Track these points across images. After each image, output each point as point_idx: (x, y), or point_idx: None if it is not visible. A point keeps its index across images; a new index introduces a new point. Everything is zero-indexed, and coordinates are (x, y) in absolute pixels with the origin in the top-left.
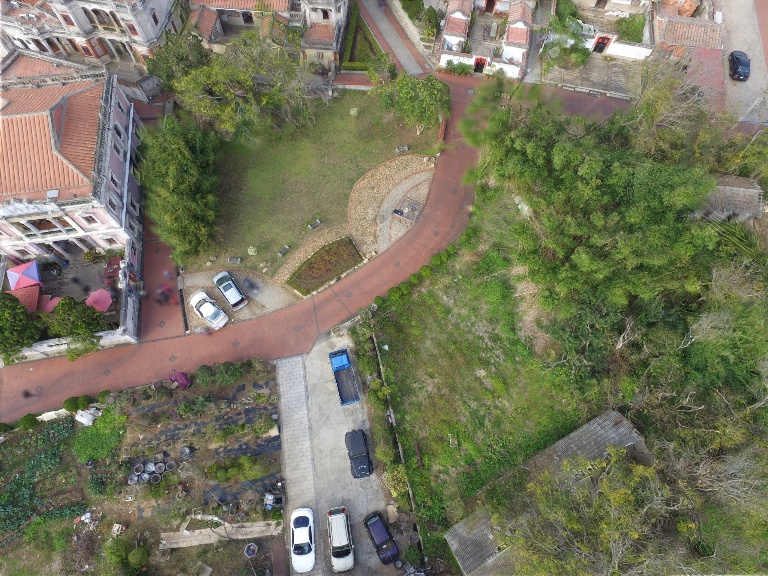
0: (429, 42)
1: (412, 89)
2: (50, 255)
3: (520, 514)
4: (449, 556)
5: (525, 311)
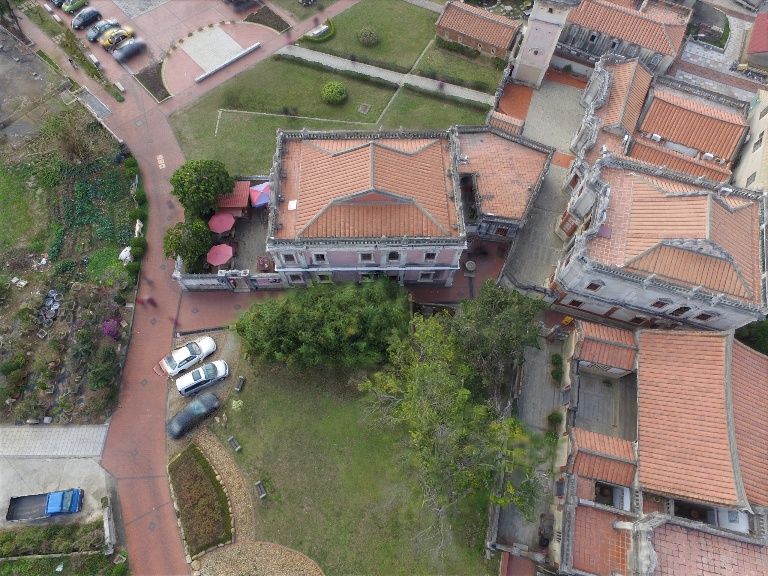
0: None
1: None
2: None
3: None
4: None
5: None
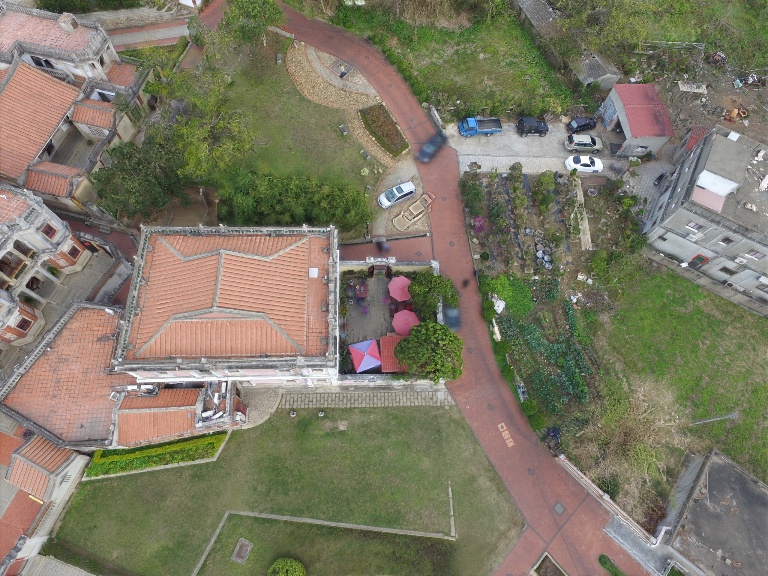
0: (165, 5)
1: (251, 4)
2: (342, 336)
3: (577, 42)
4: (594, 89)
5: (440, 24)
